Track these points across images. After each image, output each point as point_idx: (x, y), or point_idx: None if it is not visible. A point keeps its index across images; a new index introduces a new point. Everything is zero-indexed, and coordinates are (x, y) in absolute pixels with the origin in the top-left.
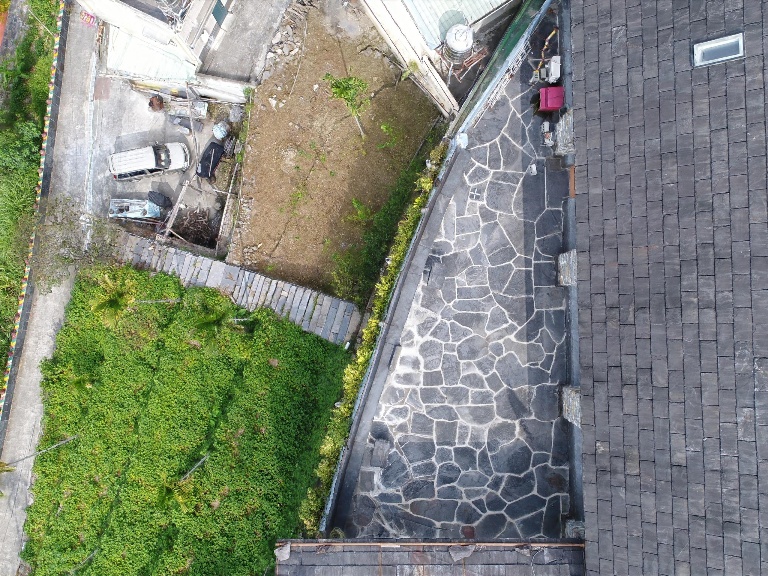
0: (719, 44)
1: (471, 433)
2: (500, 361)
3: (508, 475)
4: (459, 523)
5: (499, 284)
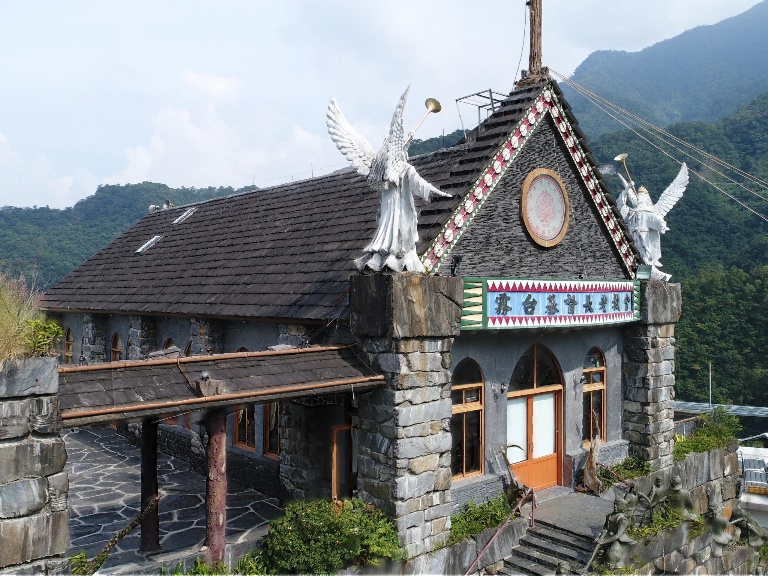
0: (147, 244)
1: (98, 507)
2: (106, 477)
3: (177, 510)
4: (129, 551)
5: (74, 459)
